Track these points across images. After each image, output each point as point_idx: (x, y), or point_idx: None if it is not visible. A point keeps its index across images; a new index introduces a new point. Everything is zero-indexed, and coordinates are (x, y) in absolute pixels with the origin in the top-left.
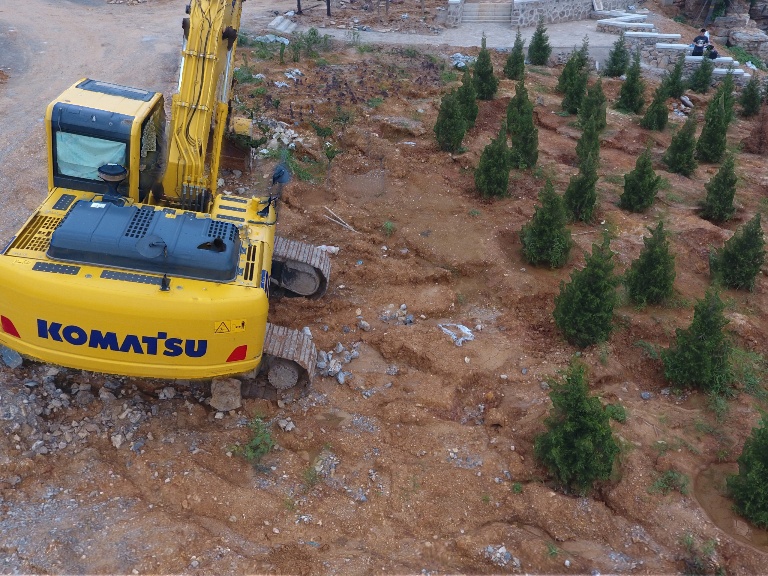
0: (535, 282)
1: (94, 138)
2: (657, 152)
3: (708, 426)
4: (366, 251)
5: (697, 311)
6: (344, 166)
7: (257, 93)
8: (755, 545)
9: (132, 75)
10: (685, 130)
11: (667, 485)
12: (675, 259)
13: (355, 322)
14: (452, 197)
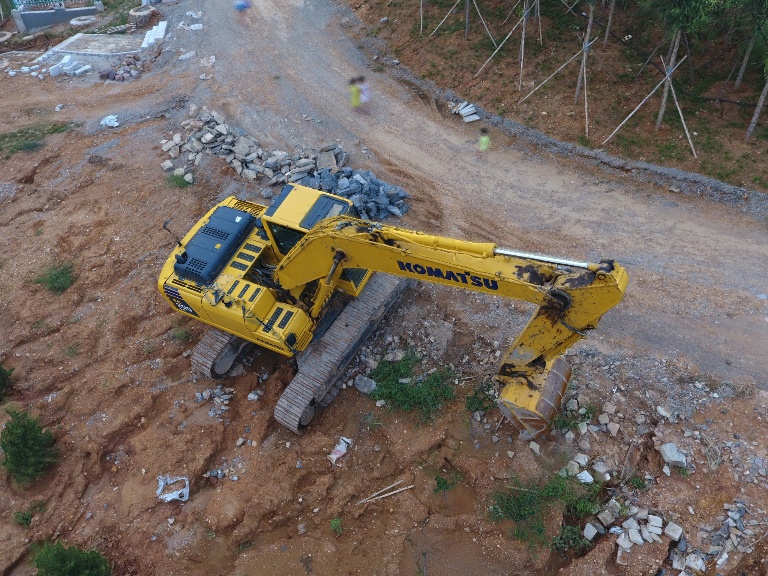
0: None
1: None
2: None
3: None
4: None
5: None
6: None
7: None
8: None
9: None
10: None
11: None
12: None
13: None
14: None
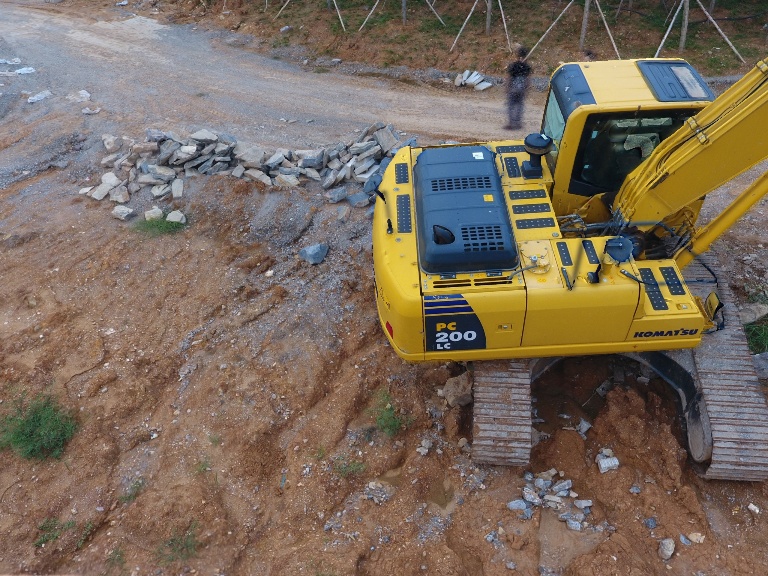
0: None
1: (559, 107)
2: None
3: None
4: None
5: None
6: None
7: None
8: None
9: None
10: None
11: None
12: None
13: (671, 533)
14: None
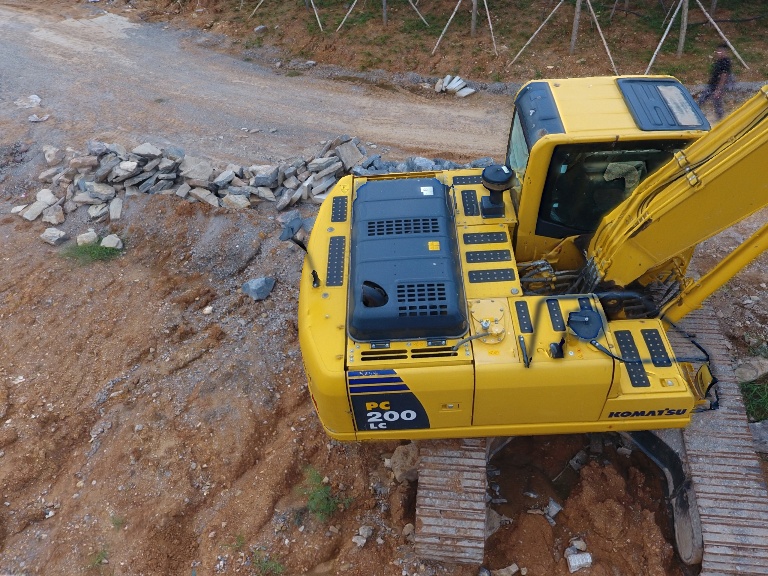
0: None
1: (523, 134)
2: None
3: None
4: None
5: None
6: None
7: None
8: None
9: None
10: None
11: None
12: None
13: None
14: None
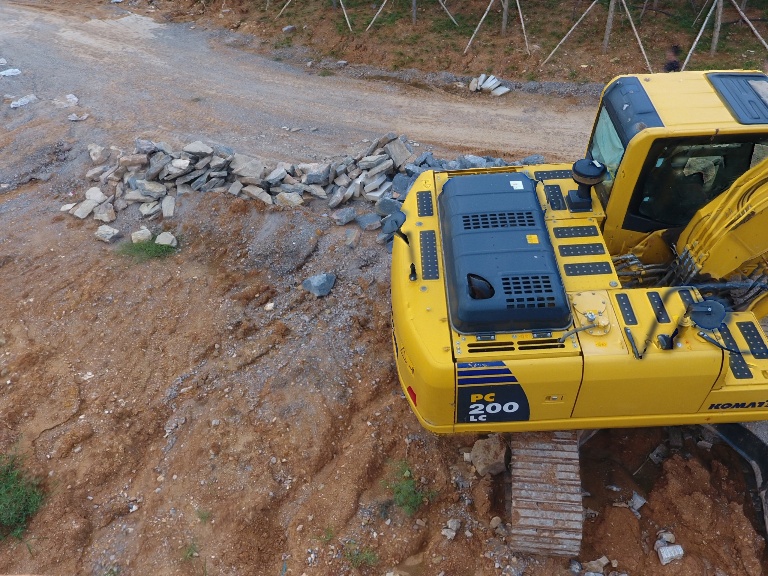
0: None
1: (614, 128)
2: None
3: None
4: None
5: None
6: None
7: None
8: None
9: None
10: None
11: None
12: None
13: None
14: None
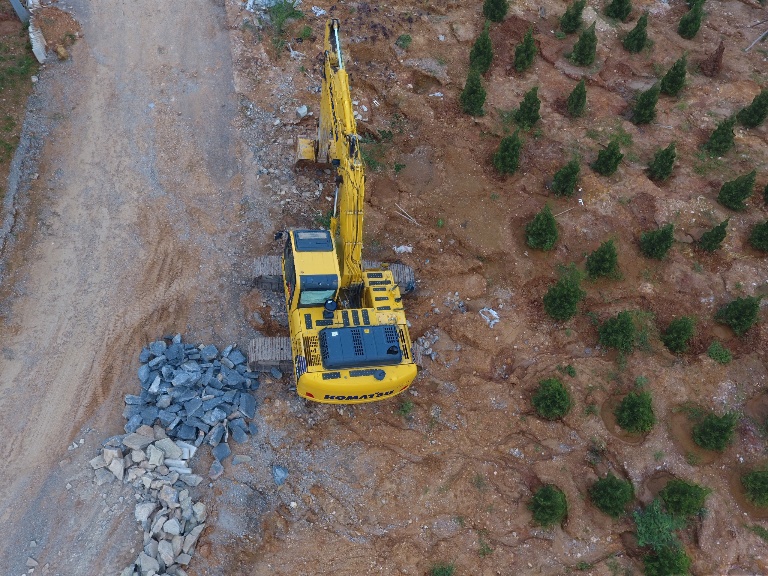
0: (534, 267)
1: (320, 291)
2: (631, 87)
3: (614, 374)
4: (429, 248)
5: (619, 316)
6: (395, 139)
7: (305, 37)
8: (621, 437)
9: (189, 17)
10: (651, 92)
11: (589, 411)
12: (621, 232)
13: (431, 309)
14: (478, 177)
